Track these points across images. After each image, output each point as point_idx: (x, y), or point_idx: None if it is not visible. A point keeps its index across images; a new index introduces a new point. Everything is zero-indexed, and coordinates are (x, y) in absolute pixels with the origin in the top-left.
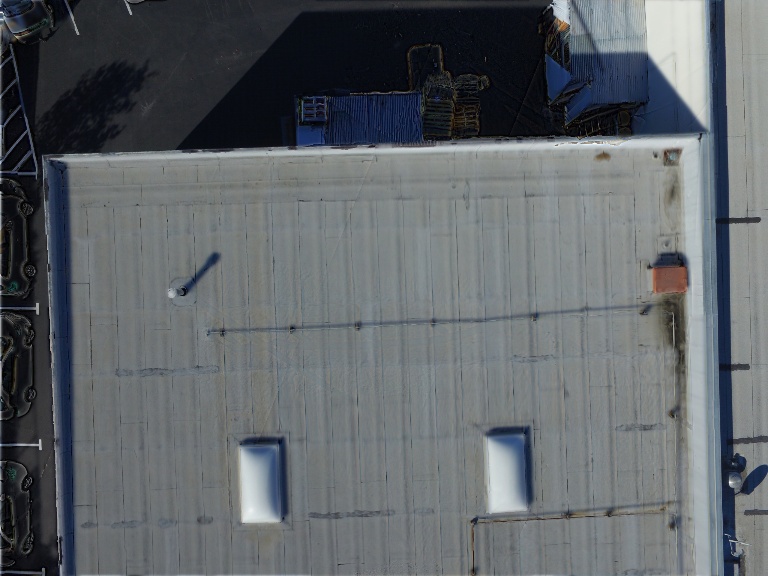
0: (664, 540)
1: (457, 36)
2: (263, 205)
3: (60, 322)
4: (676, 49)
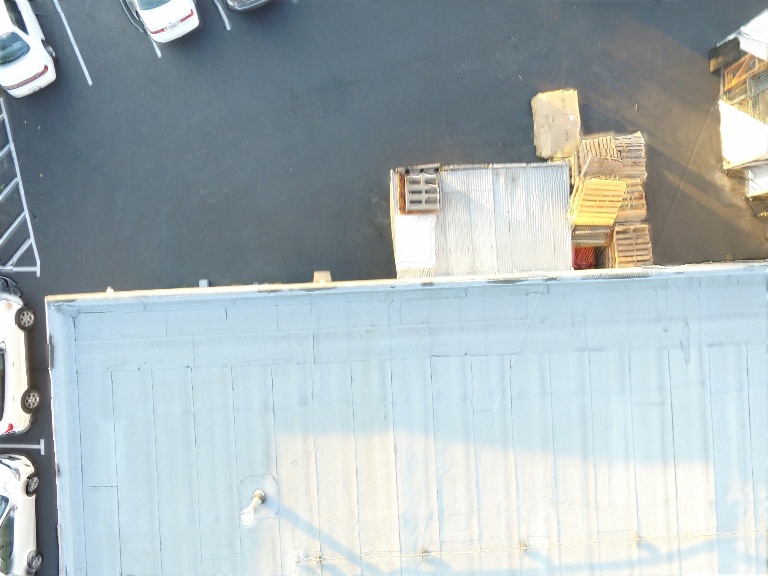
0: None
1: (597, 77)
2: (377, 364)
3: (74, 547)
4: None
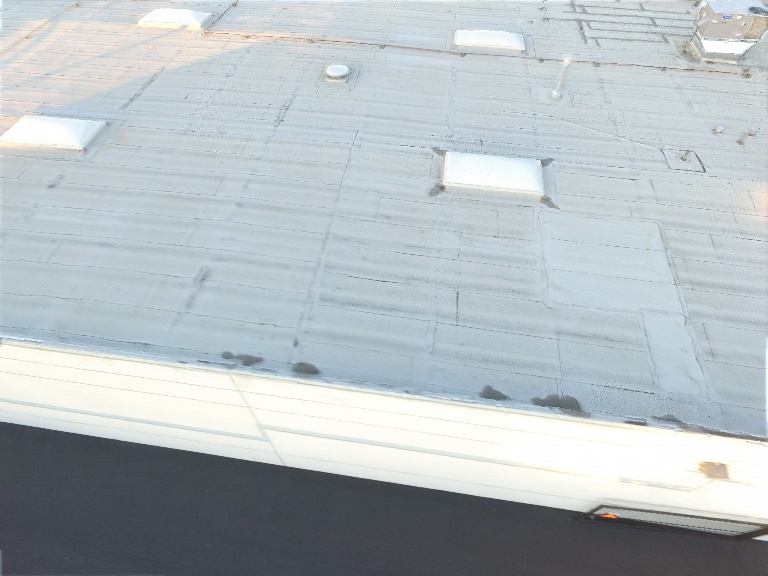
0: None
1: None
2: None
3: None
4: None
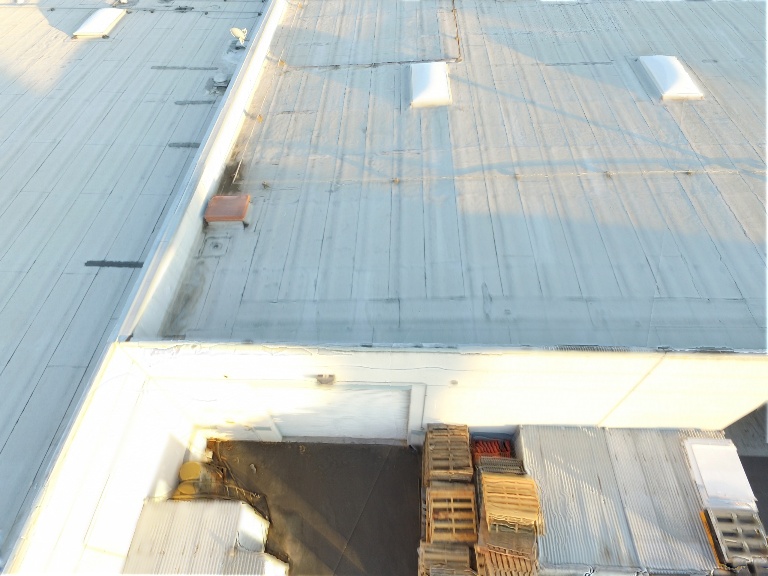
0: (291, 58)
1: None
2: None
3: None
4: (72, 567)
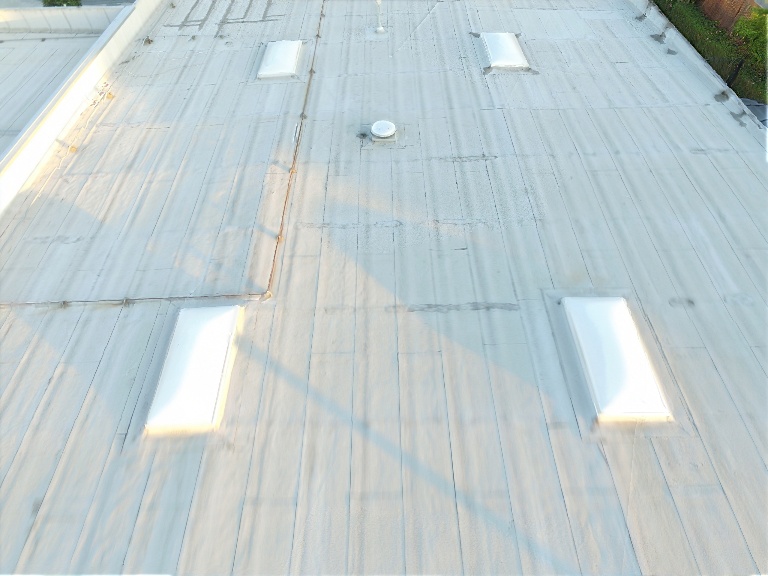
0: (6, 274)
1: None
2: None
3: None
4: None
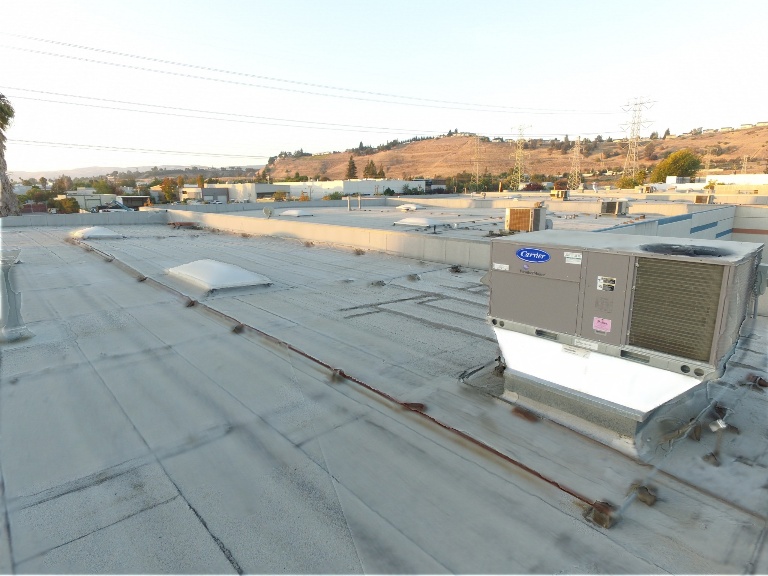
0: None
1: None
2: None
3: None
4: None
